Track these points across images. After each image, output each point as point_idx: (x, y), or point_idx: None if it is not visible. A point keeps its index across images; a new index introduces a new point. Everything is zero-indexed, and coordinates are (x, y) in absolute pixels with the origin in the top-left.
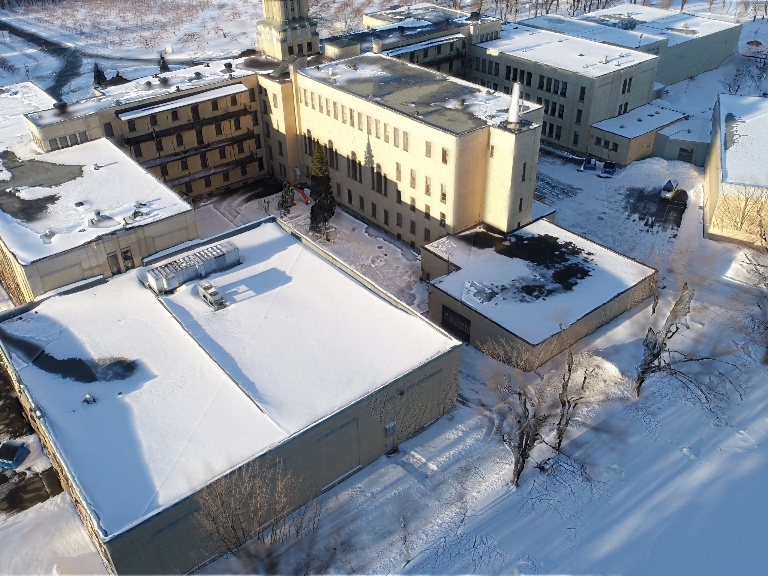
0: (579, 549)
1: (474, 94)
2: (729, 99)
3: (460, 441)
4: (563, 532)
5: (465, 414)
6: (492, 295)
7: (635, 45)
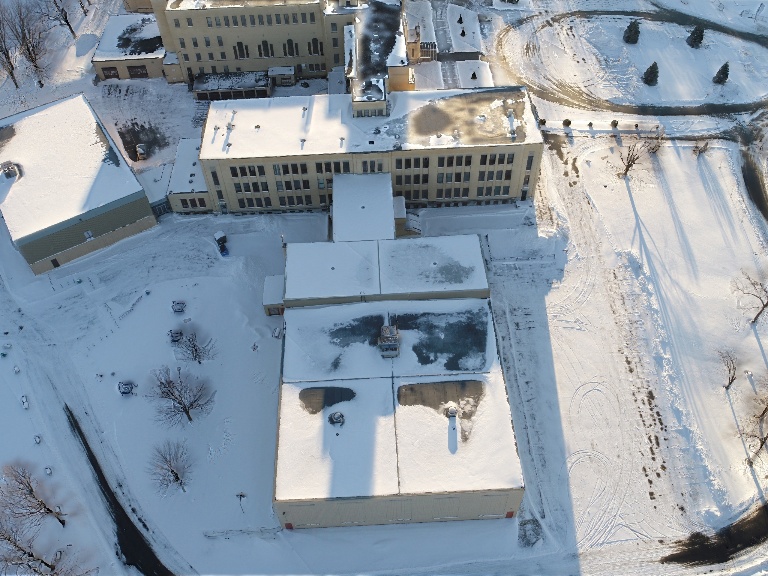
0: (64, 3)
1: (211, 3)
2: (131, 184)
3: (115, 4)
4: (70, 4)
5: (123, 11)
6: (144, 22)
7: (297, 254)
